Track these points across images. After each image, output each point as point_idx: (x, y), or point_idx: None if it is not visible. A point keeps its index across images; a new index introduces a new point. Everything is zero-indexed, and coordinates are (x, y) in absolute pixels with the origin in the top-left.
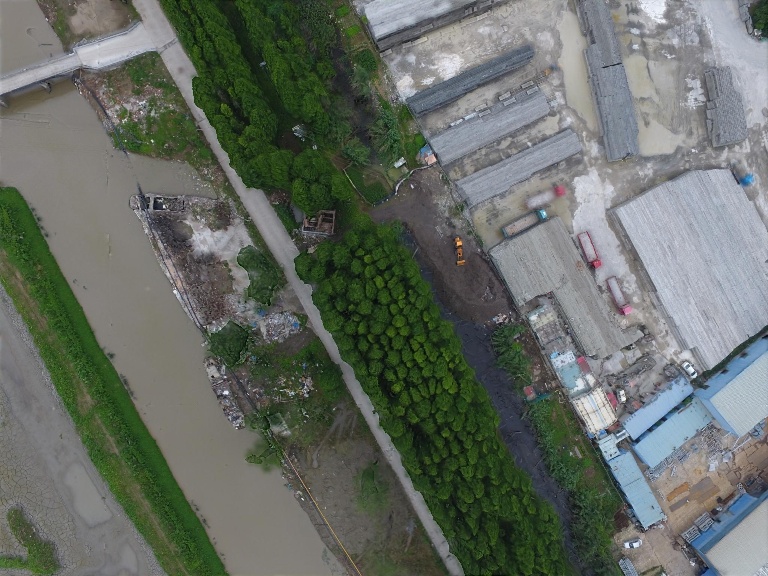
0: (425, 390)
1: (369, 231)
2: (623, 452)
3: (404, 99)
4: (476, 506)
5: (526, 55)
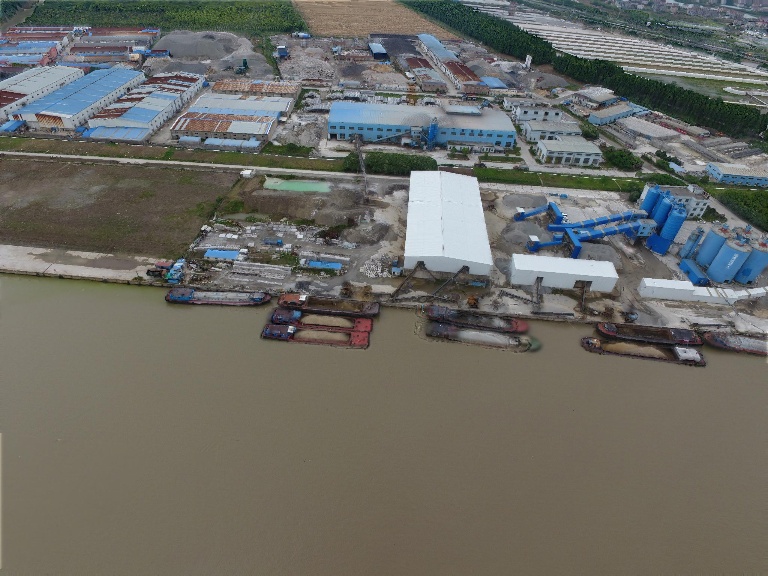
0: None
1: (757, 119)
2: (646, 110)
3: (763, 153)
4: (694, 94)
5: (736, 154)
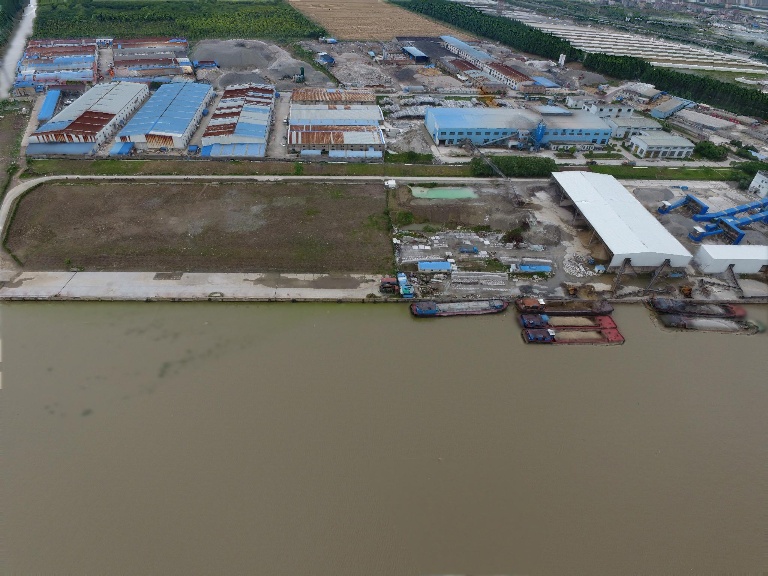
0: (761, 94)
1: None
2: None
3: None
4: (733, 86)
5: None
